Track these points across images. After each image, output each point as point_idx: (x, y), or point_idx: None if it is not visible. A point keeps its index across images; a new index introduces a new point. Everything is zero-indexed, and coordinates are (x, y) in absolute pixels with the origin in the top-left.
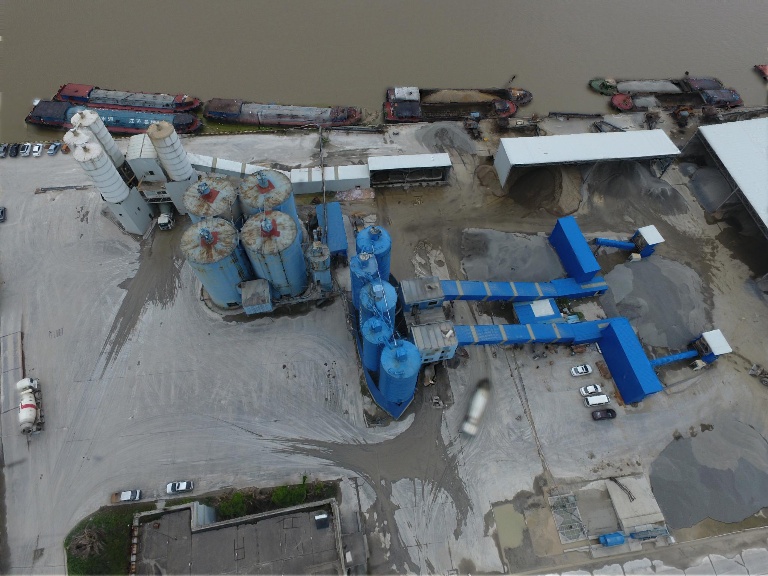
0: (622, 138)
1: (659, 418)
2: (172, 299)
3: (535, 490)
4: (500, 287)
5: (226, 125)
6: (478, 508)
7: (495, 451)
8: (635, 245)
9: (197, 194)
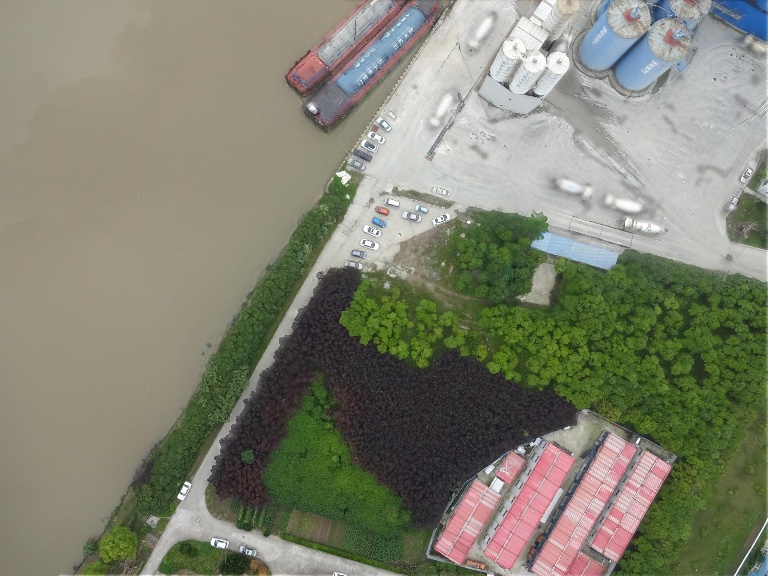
0: None
1: None
2: (613, 116)
3: None
4: None
5: None
6: None
7: None
8: None
9: (623, 23)
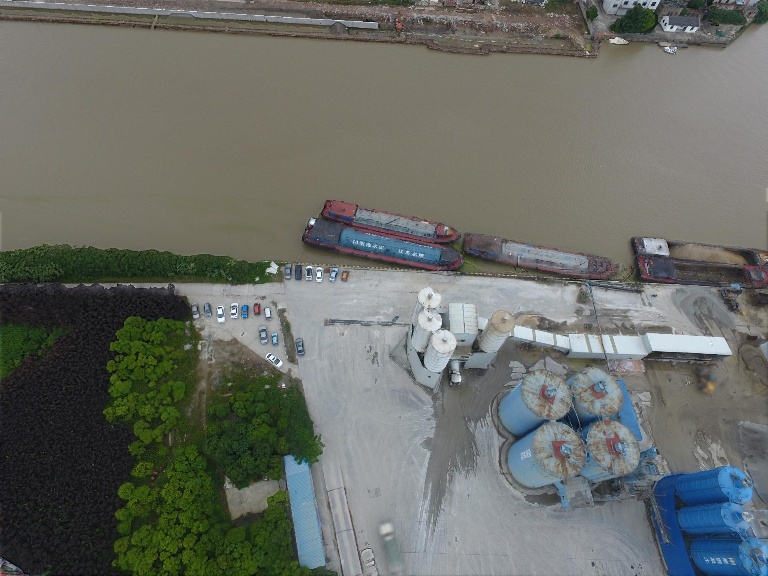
0: None
1: None
2: (473, 468)
3: None
4: None
5: (483, 261)
6: None
7: None
8: None
9: (536, 391)
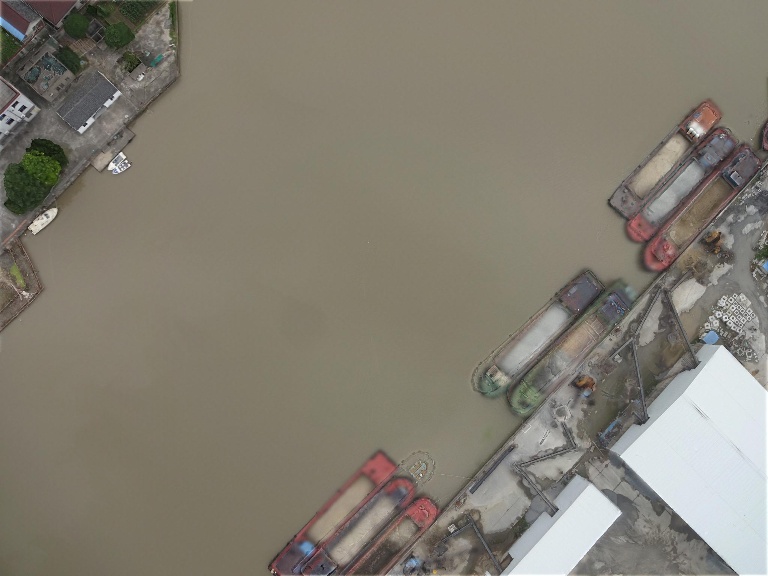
0: (566, 527)
1: None
2: None
3: None
4: None
5: None
6: None
7: None
8: None
9: None
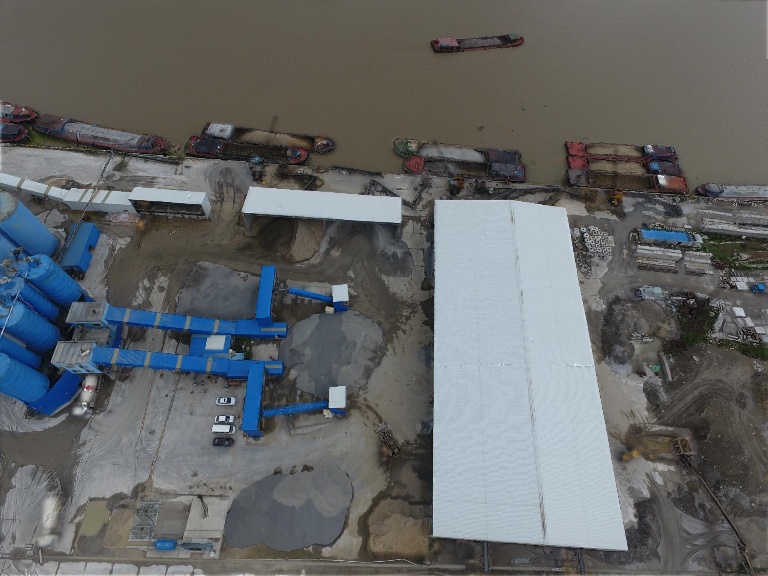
0: (359, 201)
1: (271, 453)
2: None
3: (132, 494)
4: (173, 319)
5: (52, 139)
6: (77, 499)
7: (117, 456)
8: (332, 299)
9: None
